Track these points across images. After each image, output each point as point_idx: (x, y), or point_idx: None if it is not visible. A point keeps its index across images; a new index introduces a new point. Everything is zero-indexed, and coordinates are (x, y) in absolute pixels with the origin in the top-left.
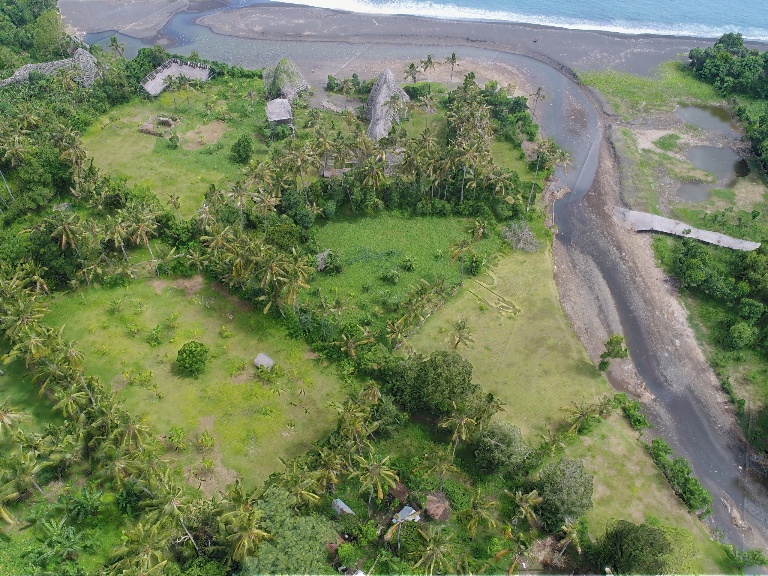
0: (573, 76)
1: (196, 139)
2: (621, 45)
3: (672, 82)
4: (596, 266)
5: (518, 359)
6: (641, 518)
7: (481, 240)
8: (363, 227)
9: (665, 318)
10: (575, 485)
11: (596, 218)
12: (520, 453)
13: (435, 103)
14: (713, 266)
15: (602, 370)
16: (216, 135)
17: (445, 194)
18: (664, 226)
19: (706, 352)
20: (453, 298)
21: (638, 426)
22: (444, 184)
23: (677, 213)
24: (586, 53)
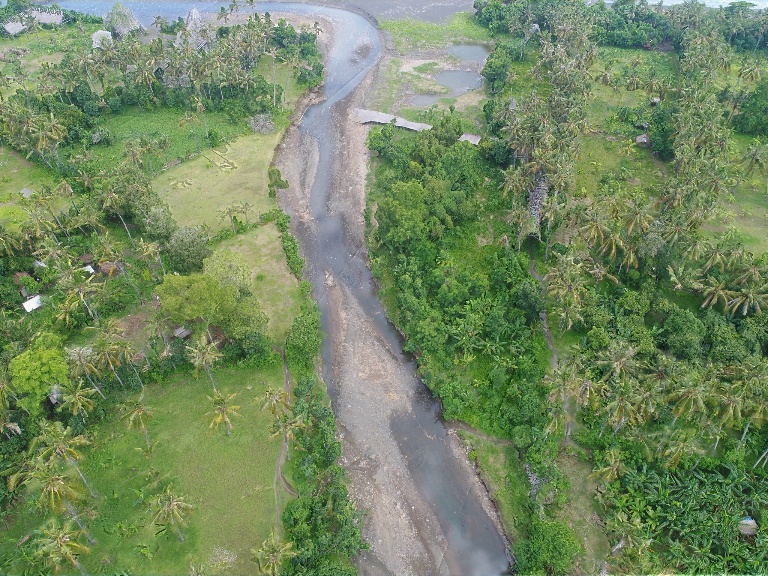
0: (376, 23)
1: (38, 64)
2: (429, 1)
3: (455, 26)
4: (317, 145)
5: (218, 194)
6: (254, 276)
7: (231, 127)
8: (143, 119)
9: (350, 175)
10: (183, 236)
11: (336, 116)
12: (165, 228)
13: (214, 29)
14: (406, 143)
15: (271, 197)
16: (55, 62)
17: (210, 94)
18: (383, 119)
19: (367, 193)
20: (190, 160)
21: (280, 228)
22: (209, 87)
23: (401, 112)
24: (395, 6)
